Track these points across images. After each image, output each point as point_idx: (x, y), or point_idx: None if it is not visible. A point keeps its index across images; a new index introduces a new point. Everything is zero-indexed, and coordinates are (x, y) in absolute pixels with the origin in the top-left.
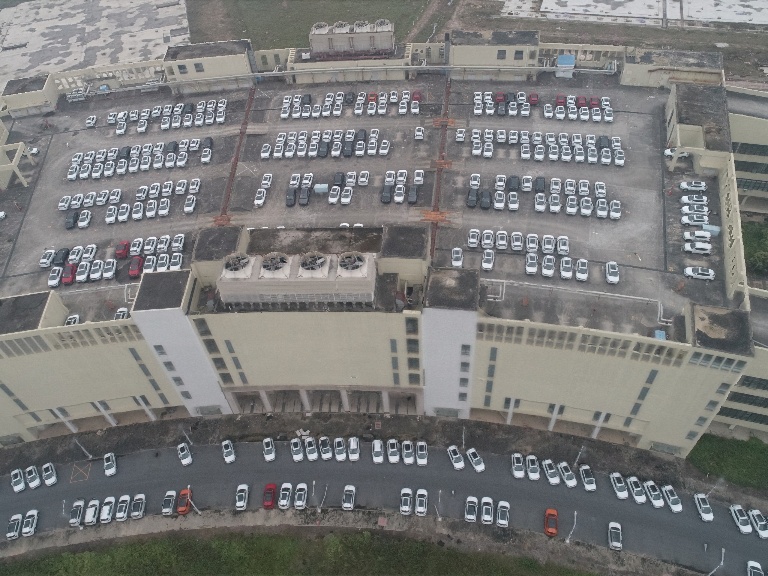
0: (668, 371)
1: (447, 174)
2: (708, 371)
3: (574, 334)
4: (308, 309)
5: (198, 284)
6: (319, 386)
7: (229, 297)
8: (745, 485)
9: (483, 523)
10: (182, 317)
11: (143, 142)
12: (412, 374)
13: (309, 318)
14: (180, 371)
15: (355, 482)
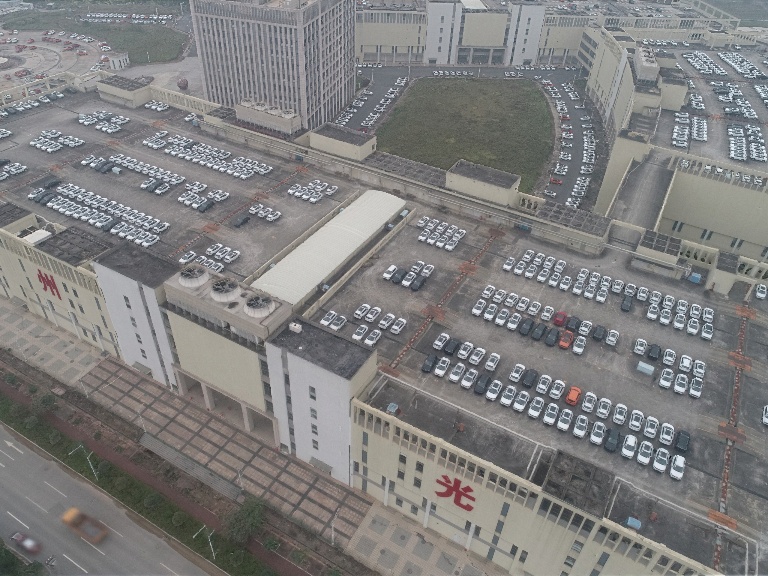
0: None
1: (759, 125)
2: None
3: None
4: None
5: None
6: (615, 124)
7: None
8: None
9: None
10: None
11: (759, 67)
12: None
13: None
14: None
15: (574, 148)
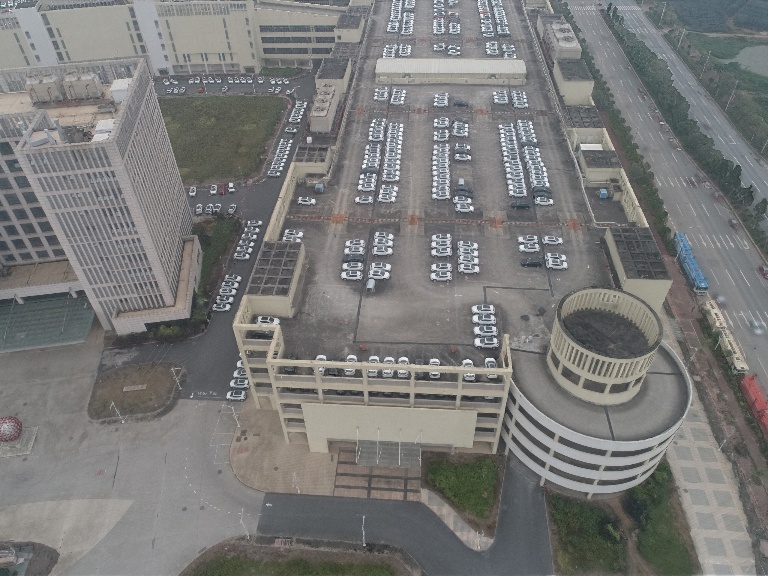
0: (228, 18)
1: None
2: (238, 13)
3: (190, 5)
4: (89, 7)
5: (42, 8)
6: (103, 59)
7: (55, 2)
8: (279, 76)
9: (174, 92)
10: (36, 12)
11: None
12: (141, 46)
13: (90, 11)
14: (38, 51)
15: None
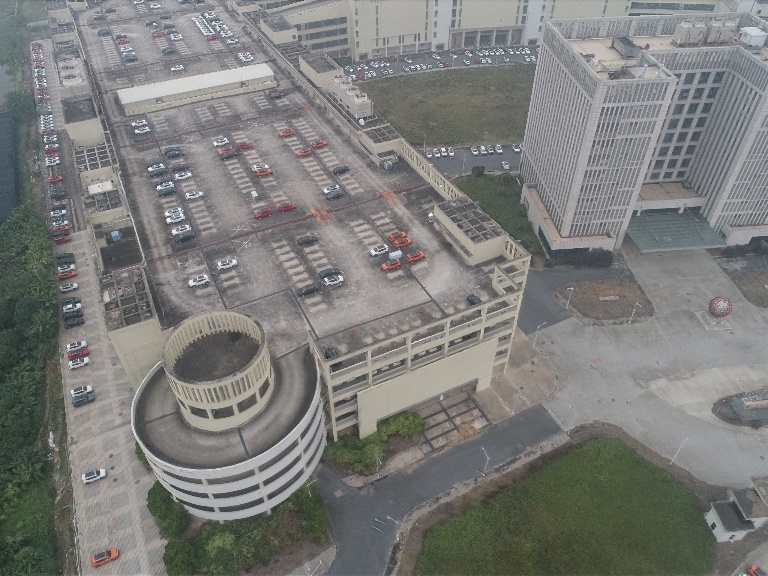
0: None
1: None
2: None
3: None
4: None
5: None
6: (487, 28)
7: None
8: None
9: None
10: None
11: None
12: (523, 17)
13: None
14: (438, 18)
15: None
